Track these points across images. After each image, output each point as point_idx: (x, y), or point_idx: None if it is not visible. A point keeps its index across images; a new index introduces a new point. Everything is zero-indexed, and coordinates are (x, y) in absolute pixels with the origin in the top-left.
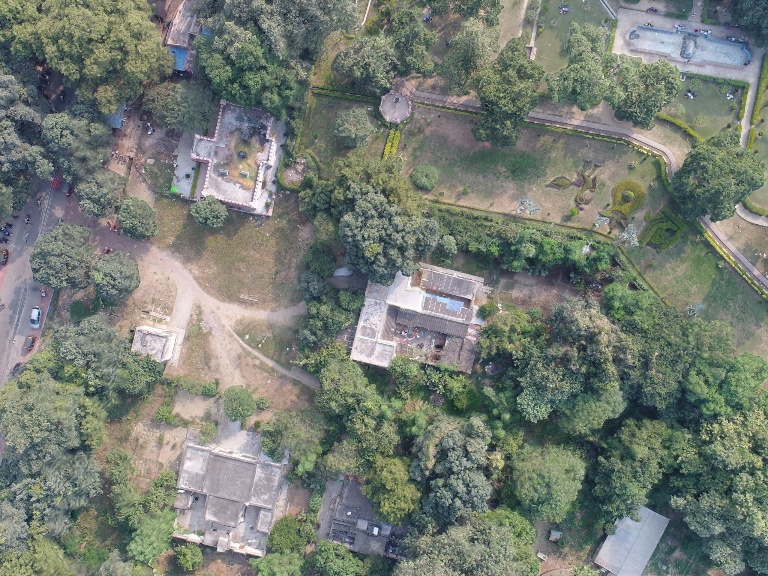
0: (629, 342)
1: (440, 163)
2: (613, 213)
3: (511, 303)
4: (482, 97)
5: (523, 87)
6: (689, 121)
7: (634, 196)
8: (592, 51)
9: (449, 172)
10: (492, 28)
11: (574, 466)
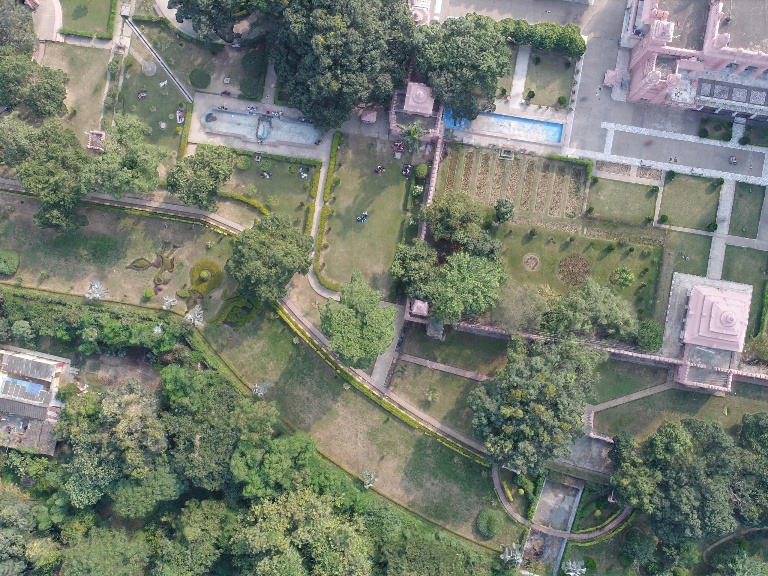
0: (155, 428)
1: (24, 248)
2: (191, 293)
3: (97, 383)
4: (25, 188)
5: (58, 179)
6: (265, 200)
7: (210, 275)
8: (118, 143)
9: (32, 256)
10: (52, 118)
11: (127, 550)
